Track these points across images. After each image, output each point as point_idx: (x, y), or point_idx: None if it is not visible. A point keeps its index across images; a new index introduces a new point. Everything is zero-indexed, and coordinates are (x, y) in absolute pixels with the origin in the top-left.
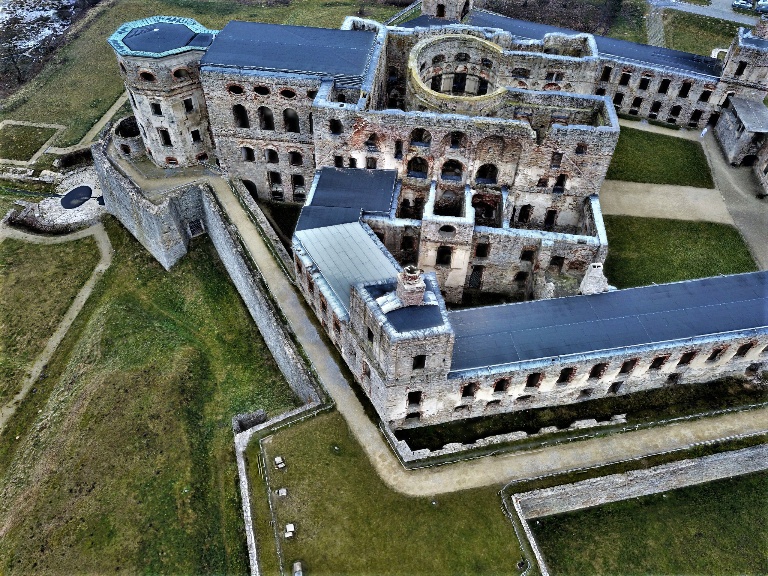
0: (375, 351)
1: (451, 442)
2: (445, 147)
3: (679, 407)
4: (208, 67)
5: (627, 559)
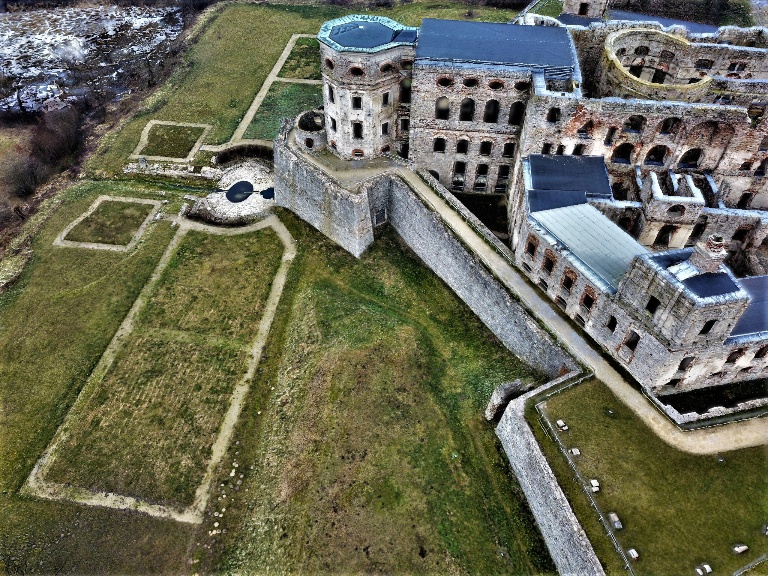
0: (658, 318)
1: (712, 407)
2: (655, 133)
3: None
4: (421, 61)
5: None
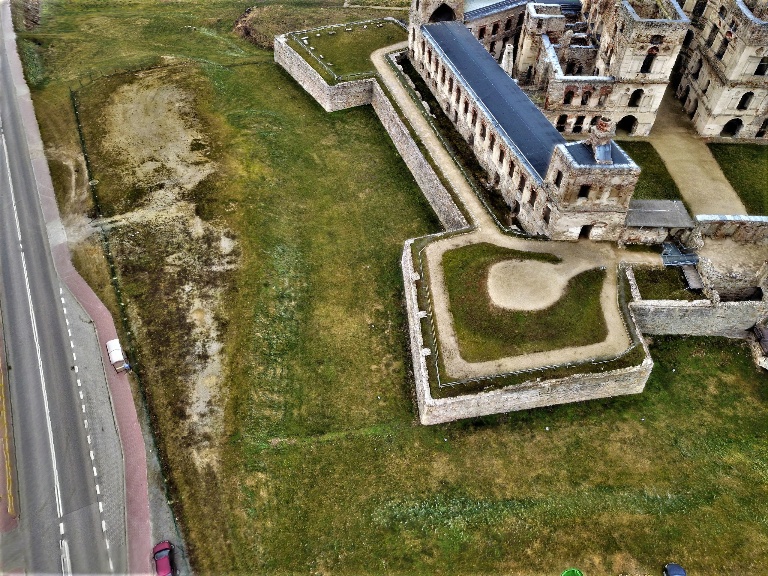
0: None
1: None
2: None
3: (446, 134)
4: None
5: (357, 137)
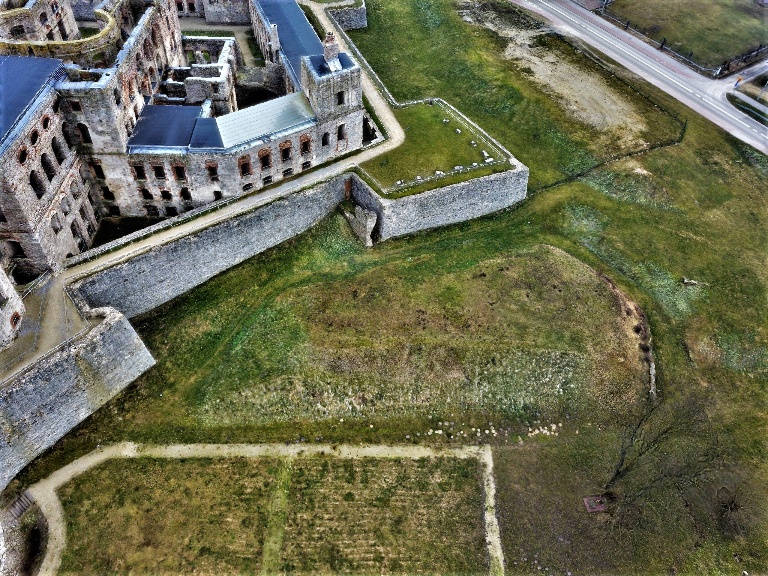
0: (347, 101)
1: None
2: None
3: None
4: None
5: (406, 97)
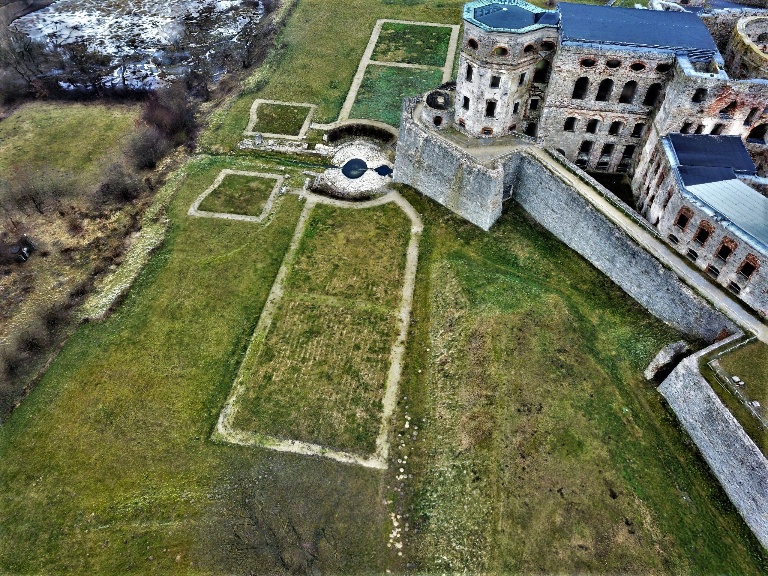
0: None
1: None
2: None
3: None
4: (569, 42)
5: None
